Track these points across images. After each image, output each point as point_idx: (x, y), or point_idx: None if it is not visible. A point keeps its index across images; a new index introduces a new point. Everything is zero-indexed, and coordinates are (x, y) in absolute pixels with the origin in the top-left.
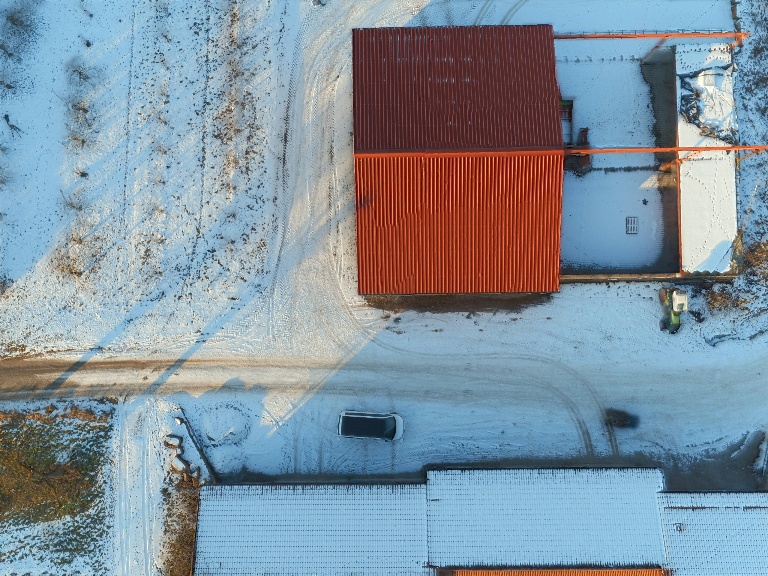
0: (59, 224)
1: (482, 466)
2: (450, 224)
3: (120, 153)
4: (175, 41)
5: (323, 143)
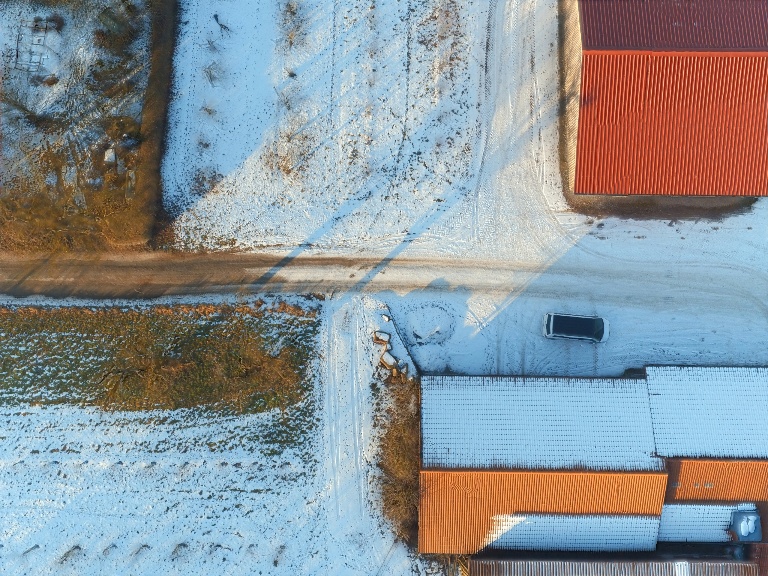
0: (268, 122)
1: None
2: (671, 124)
3: (327, 55)
4: None
5: (524, 53)
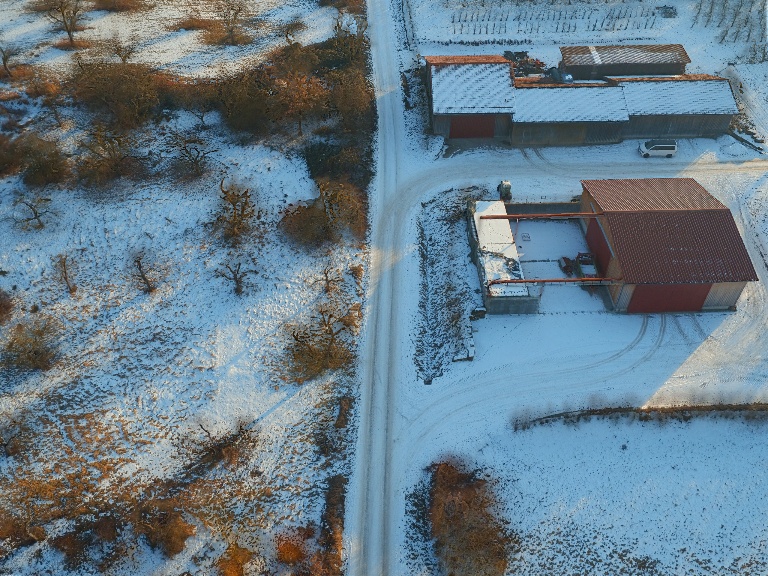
0: None
1: (591, 144)
2: None
3: None
4: None
5: None
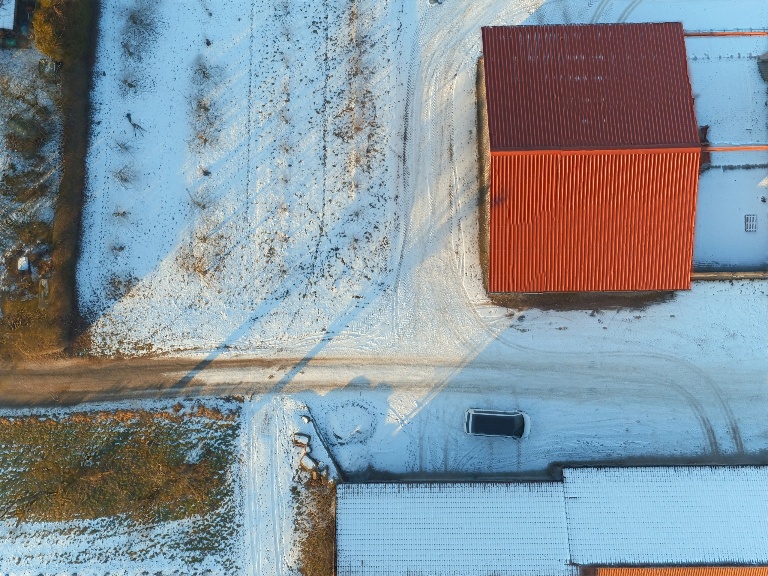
0: (183, 223)
1: (607, 464)
2: (584, 222)
3: (242, 152)
4: (294, 40)
5: (442, 141)
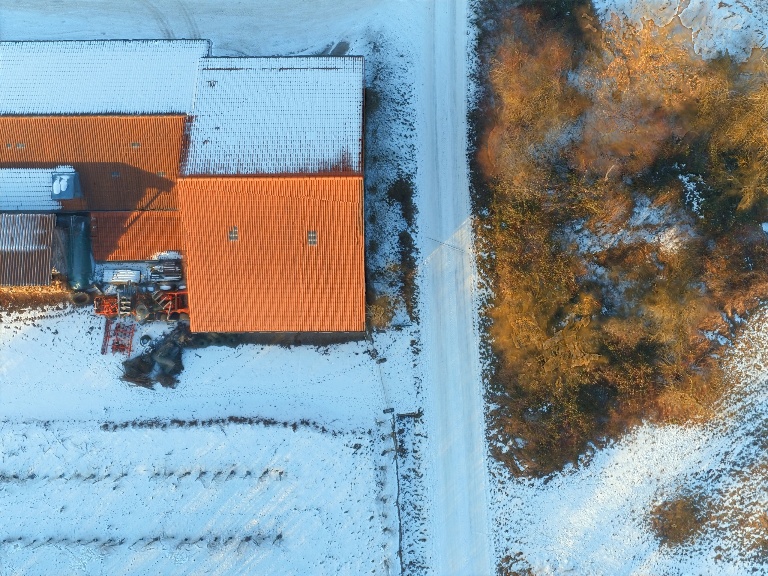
0: None
1: None
2: None
3: None
4: None
5: None
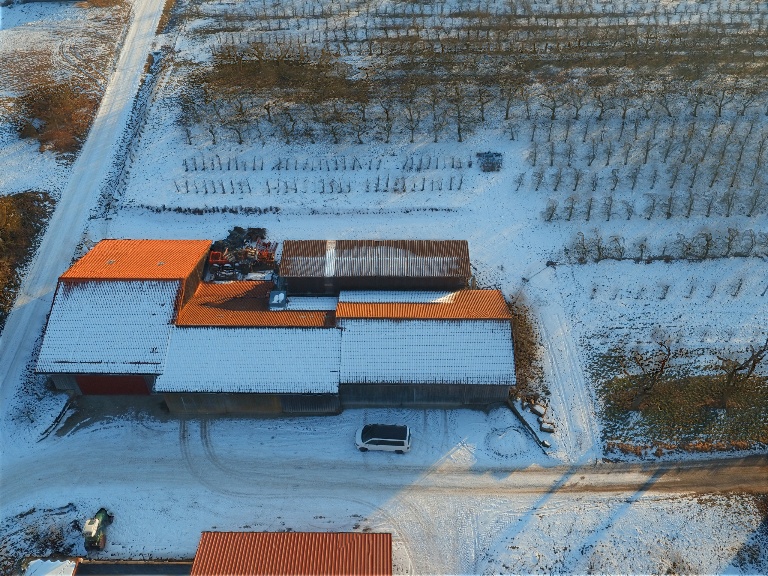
0: None
1: (293, 414)
2: None
3: None
4: None
5: None
